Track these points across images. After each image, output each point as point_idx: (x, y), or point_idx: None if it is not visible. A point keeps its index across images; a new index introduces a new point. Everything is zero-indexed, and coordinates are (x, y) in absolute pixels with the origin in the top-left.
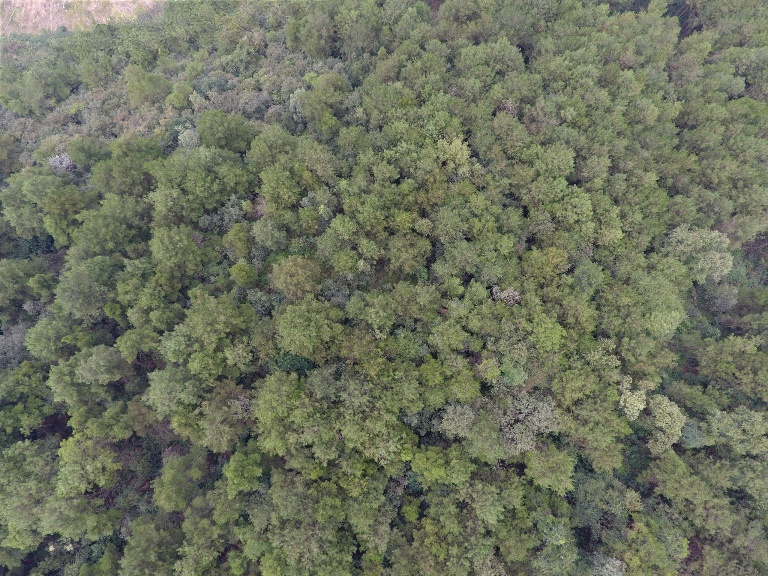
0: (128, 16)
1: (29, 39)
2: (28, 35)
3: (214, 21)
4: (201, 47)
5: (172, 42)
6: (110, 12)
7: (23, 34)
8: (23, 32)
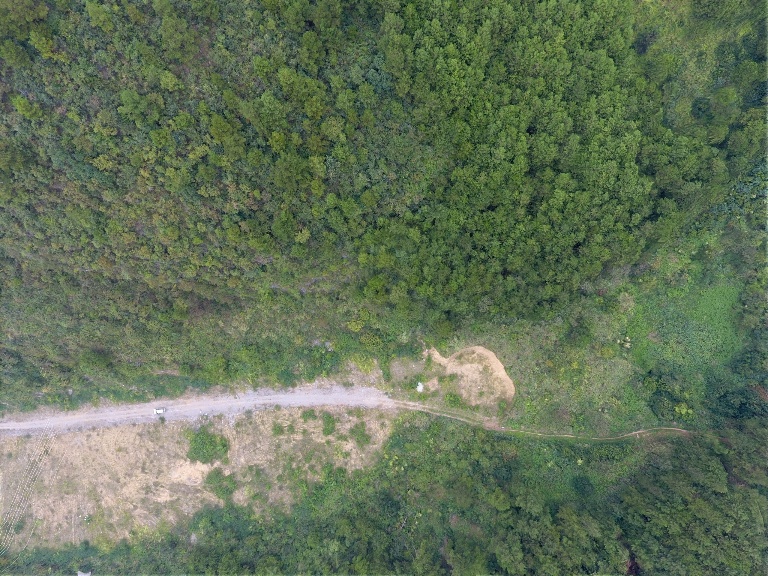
0: (151, 530)
1: (51, 559)
2: (50, 553)
3: None
4: None
5: None
6: (133, 525)
7: (45, 552)
8: (45, 546)
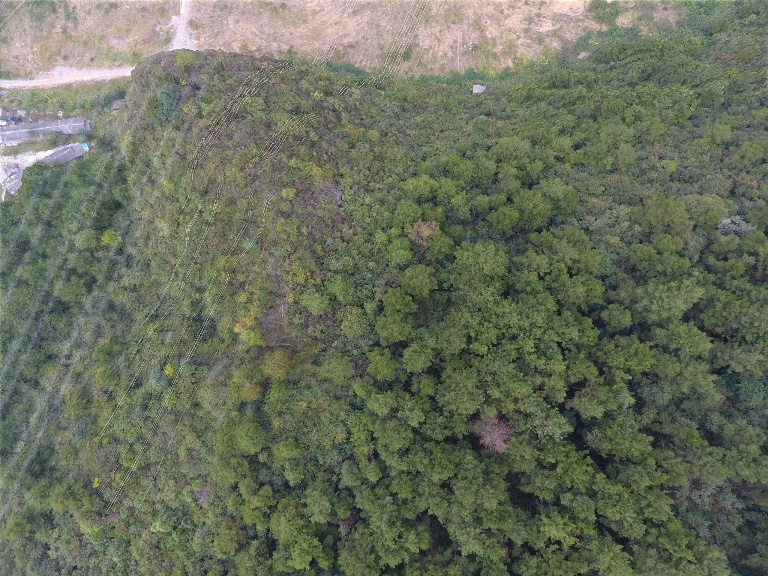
0: (535, 57)
1: (441, 81)
2: (439, 77)
3: (729, 73)
4: (741, 102)
5: (705, 97)
6: (516, 53)
7: (434, 76)
8: (431, 74)
